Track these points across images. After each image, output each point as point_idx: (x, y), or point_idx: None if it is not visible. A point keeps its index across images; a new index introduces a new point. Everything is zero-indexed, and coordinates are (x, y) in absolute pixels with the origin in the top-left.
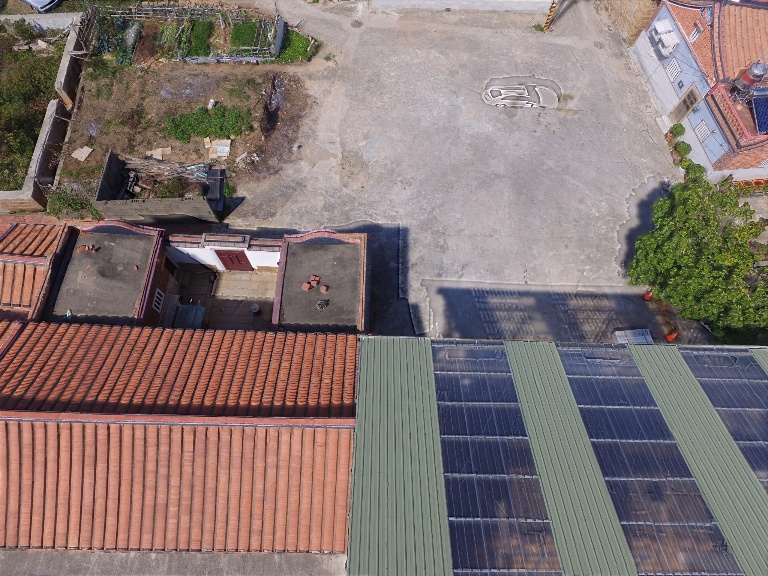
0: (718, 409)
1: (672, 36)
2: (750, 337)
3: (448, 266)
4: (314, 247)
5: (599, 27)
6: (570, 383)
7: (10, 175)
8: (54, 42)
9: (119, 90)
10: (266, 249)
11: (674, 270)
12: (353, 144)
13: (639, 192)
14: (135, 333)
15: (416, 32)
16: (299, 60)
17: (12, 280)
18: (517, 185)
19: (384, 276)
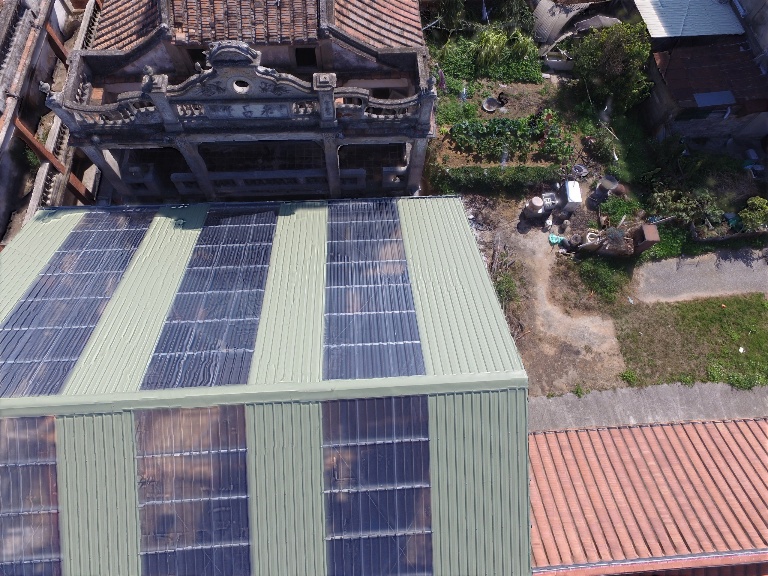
0: None
1: None
2: None
3: None
4: None
5: None
6: None
7: None
8: None
9: None
10: None
11: None
12: None
13: None
14: None
15: None
16: None
17: None
18: None
19: None
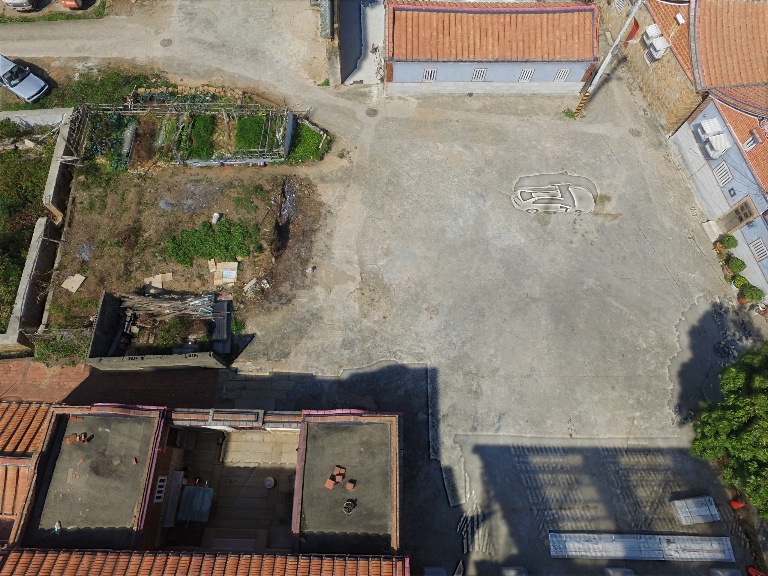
0: None
1: (722, 139)
2: None
3: (483, 416)
4: (337, 428)
5: (634, 111)
6: None
7: None
8: (42, 140)
9: (114, 202)
10: (282, 426)
11: (754, 465)
12: (372, 263)
13: (689, 316)
14: (134, 565)
15: (436, 122)
16: (310, 160)
17: None
18: (555, 311)
19: (412, 431)
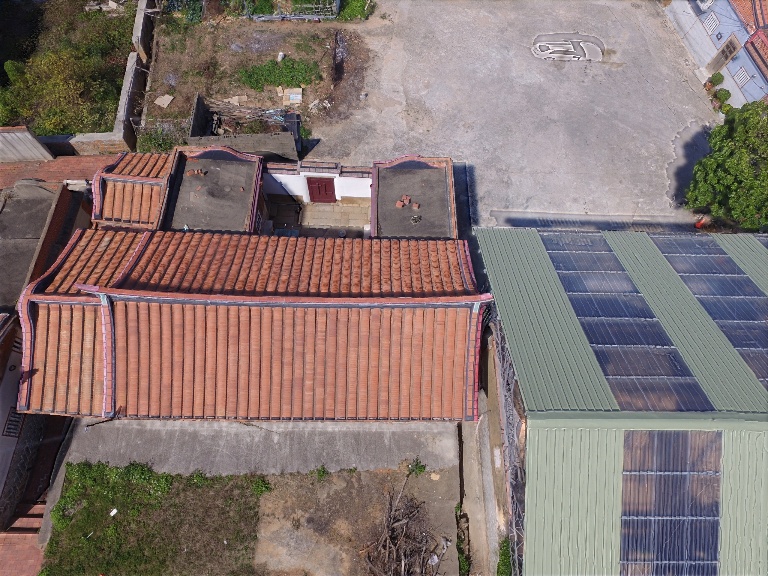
0: None
1: None
2: None
3: (514, 199)
4: (402, 171)
5: None
6: (667, 259)
7: (100, 119)
8: (123, 3)
9: (192, 44)
10: (356, 175)
11: (735, 185)
12: (416, 93)
13: (683, 135)
14: (254, 240)
15: None
16: (358, 18)
17: (131, 199)
18: (571, 129)
19: None
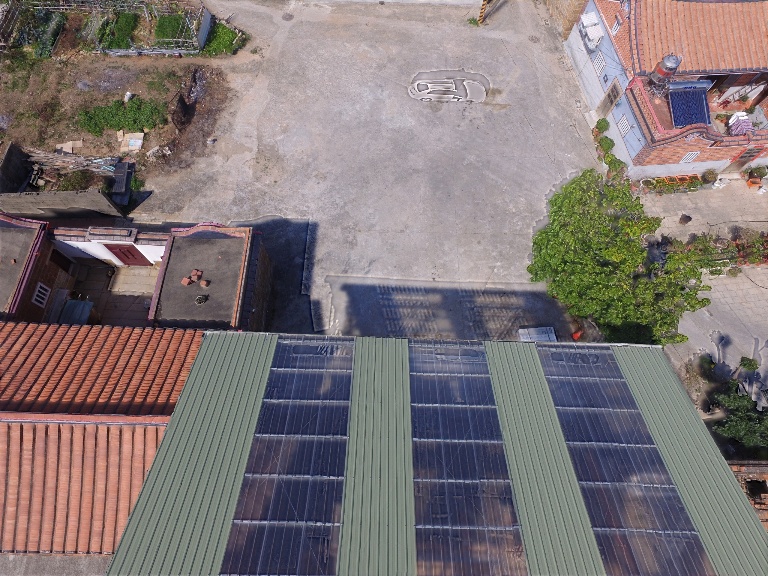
0: (558, 408)
1: (597, 29)
2: (634, 335)
3: (355, 262)
4: (200, 241)
5: (536, 21)
6: (411, 381)
7: None
8: None
9: (35, 82)
10: (154, 243)
11: (562, 266)
12: (270, 138)
13: (560, 188)
14: None
15: (347, 25)
16: (224, 53)
17: None
18: (434, 180)
19: (288, 272)
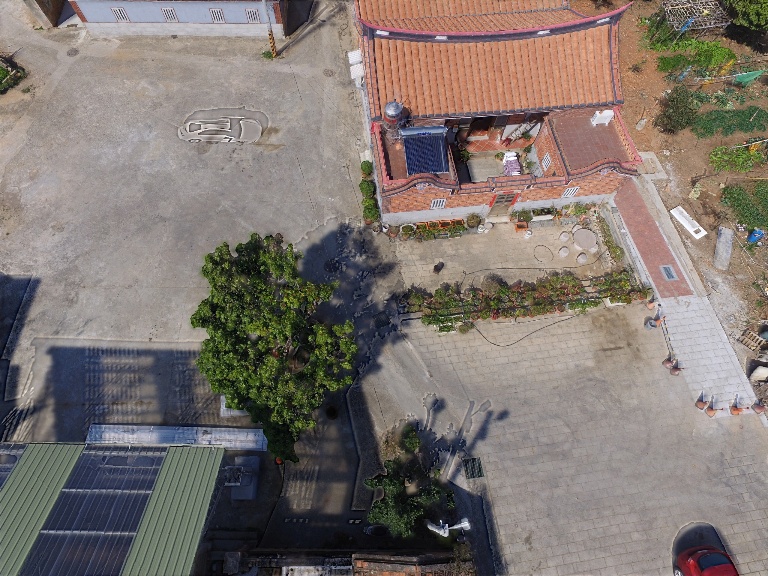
0: (43, 533)
1: (360, 68)
2: None
3: (70, 322)
4: None
5: (336, 53)
6: None
7: None
8: None
9: None
10: None
11: None
12: (15, 186)
13: (313, 235)
14: None
15: (131, 61)
16: None
17: None
18: (180, 229)
19: None
